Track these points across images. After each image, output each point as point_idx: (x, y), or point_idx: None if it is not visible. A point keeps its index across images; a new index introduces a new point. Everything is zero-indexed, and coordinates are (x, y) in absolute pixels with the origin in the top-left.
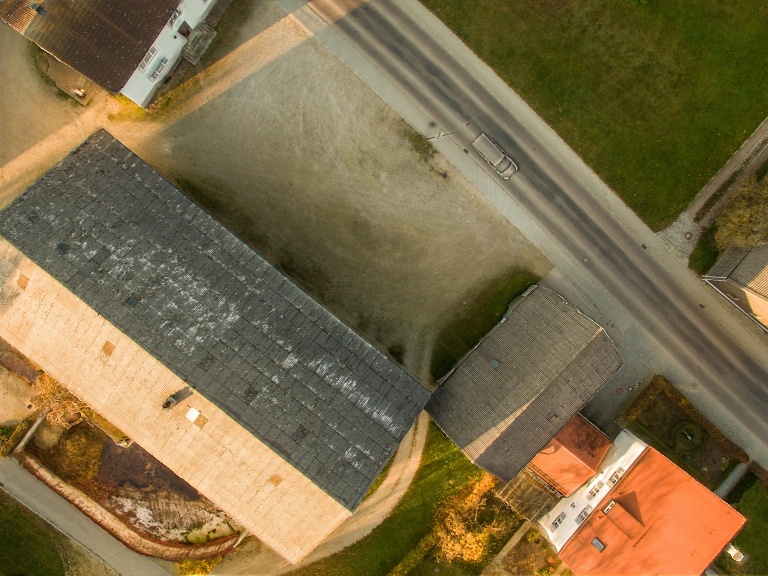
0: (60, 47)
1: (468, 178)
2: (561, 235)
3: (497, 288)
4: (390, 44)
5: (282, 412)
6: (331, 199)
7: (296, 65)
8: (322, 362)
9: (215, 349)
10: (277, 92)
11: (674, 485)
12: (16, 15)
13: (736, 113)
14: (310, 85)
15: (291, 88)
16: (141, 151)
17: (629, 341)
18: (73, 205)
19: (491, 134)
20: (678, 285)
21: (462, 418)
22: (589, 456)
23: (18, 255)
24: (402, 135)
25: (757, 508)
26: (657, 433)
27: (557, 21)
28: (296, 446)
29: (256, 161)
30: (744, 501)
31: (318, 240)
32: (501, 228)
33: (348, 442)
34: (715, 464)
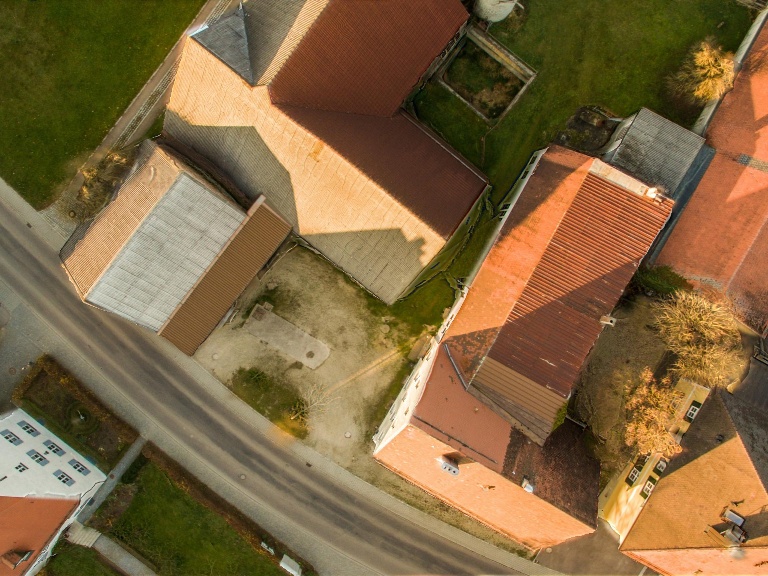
0: None
1: None
2: None
3: None
4: None
5: None
6: None
7: None
8: None
9: None
10: None
11: None
12: None
13: (108, 90)
14: None
15: None
16: None
17: (17, 320)
18: None
19: None
20: None
21: None
22: None
23: None
24: None
25: (159, 488)
26: (52, 413)
27: None
28: None
29: None
30: (145, 481)
31: None
32: None
33: None
34: (112, 444)
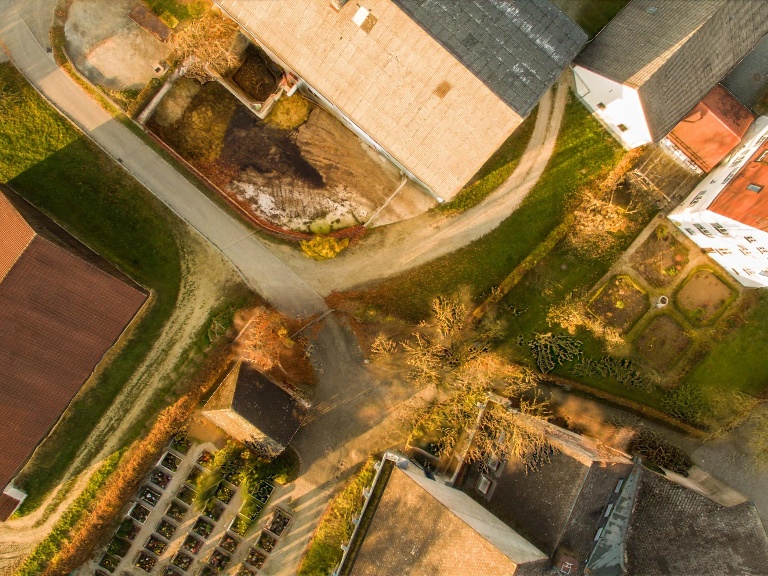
0: None
1: None
2: None
3: None
4: None
5: (452, 19)
6: None
7: None
8: None
9: None
10: None
11: None
12: None
13: None
14: None
15: None
16: None
17: None
18: None
19: None
20: None
21: (620, 59)
22: (734, 124)
23: None
24: None
25: None
26: None
27: None
28: (467, 51)
29: None
30: None
31: None
32: None
33: (515, 58)
34: None
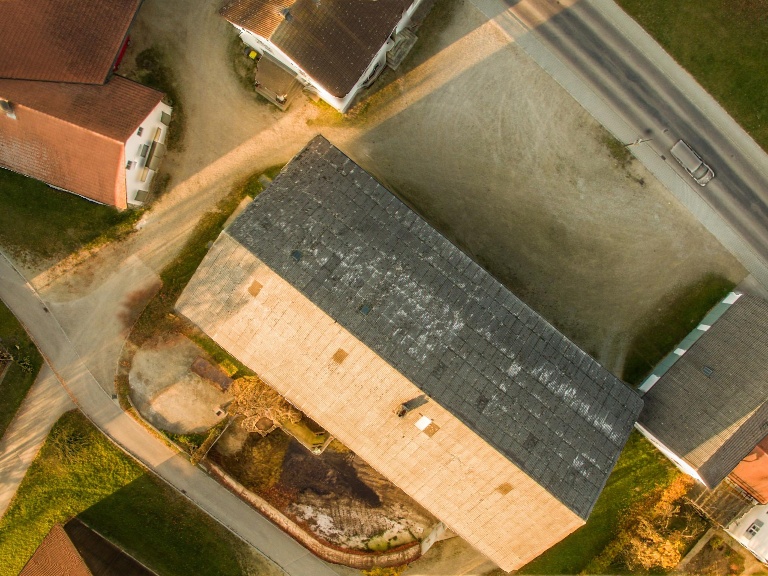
0: (300, 53)
1: (665, 185)
2: (756, 242)
3: (692, 295)
4: (590, 50)
5: (512, 420)
6: (528, 205)
7: (496, 71)
8: (543, 370)
9: (445, 357)
10: (476, 98)
11: None
12: (255, 20)
13: None
14: (509, 91)
15: (490, 94)
16: (354, 157)
17: None
18: (301, 212)
19: (689, 141)
20: None
21: (677, 426)
22: None
23: (255, 262)
24: (600, 141)
25: None
26: None
27: (757, 28)
28: (528, 455)
29: (454, 167)
30: None
31: (514, 246)
32: (697, 235)
33: (575, 450)
34: None
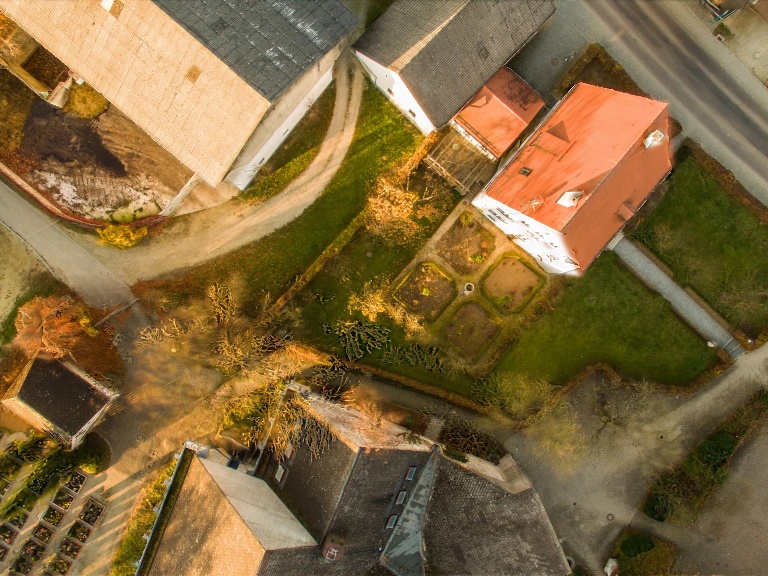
0: None
1: None
2: None
3: None
4: None
5: (202, 3)
6: None
7: None
8: None
9: None
10: None
11: (601, 102)
12: None
13: None
14: None
15: None
16: None
17: (565, 9)
18: None
19: None
20: None
21: (390, 43)
22: (521, 108)
23: None
24: None
25: (690, 188)
26: None
27: None
28: (215, 35)
29: None
30: (677, 180)
31: None
32: None
33: (270, 43)
34: None
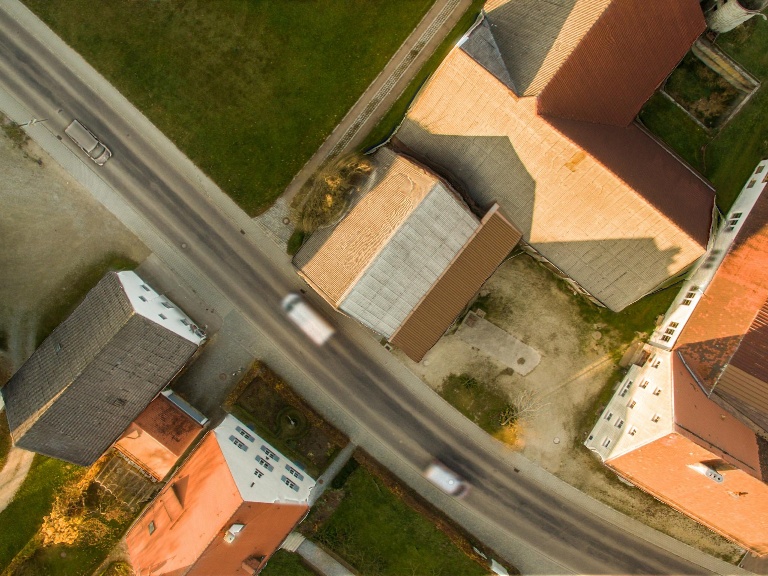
0: None
1: (62, 164)
2: (158, 221)
3: (95, 274)
4: None
5: None
6: None
7: None
8: None
9: None
10: None
11: (213, 468)
12: None
13: (326, 98)
14: None
15: None
16: None
17: (230, 326)
18: None
19: (83, 120)
20: (278, 270)
21: (21, 402)
22: (173, 440)
23: None
24: None
25: (366, 493)
26: (262, 418)
27: (143, 7)
28: None
29: None
30: (352, 486)
31: None
32: (97, 214)
33: None
34: (321, 449)
